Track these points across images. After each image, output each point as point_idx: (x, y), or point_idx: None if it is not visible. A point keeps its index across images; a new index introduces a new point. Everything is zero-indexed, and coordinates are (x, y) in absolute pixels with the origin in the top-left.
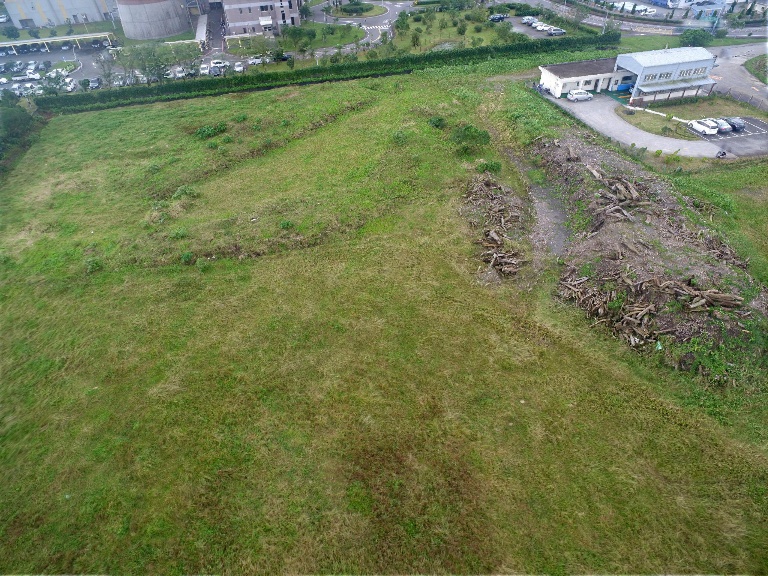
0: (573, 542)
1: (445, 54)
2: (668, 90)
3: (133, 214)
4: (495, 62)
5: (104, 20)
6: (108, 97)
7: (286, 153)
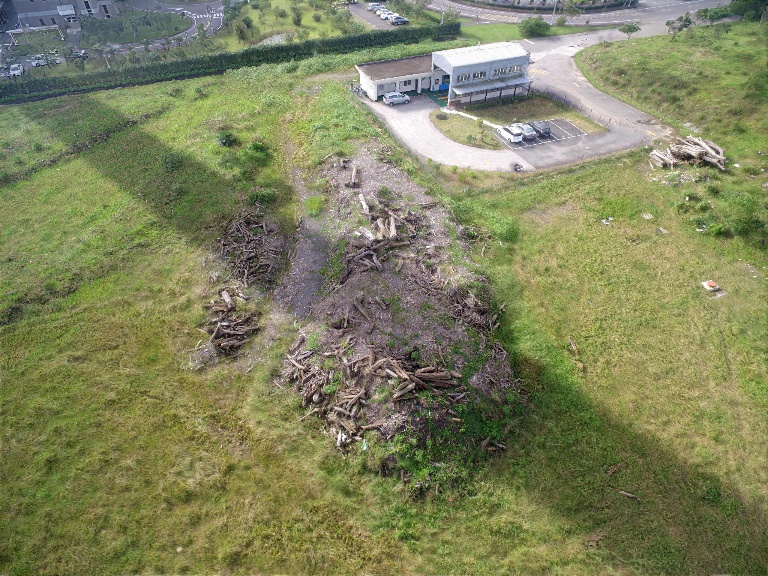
0: None
1: (265, 50)
2: None
3: None
4: (320, 58)
5: None
6: None
7: (26, 188)
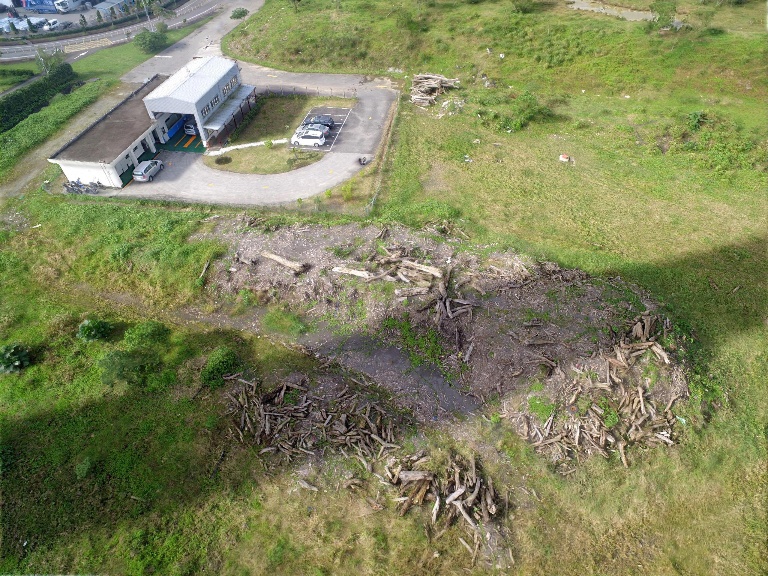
0: None
1: None
2: None
3: None
4: None
5: None
6: None
7: None
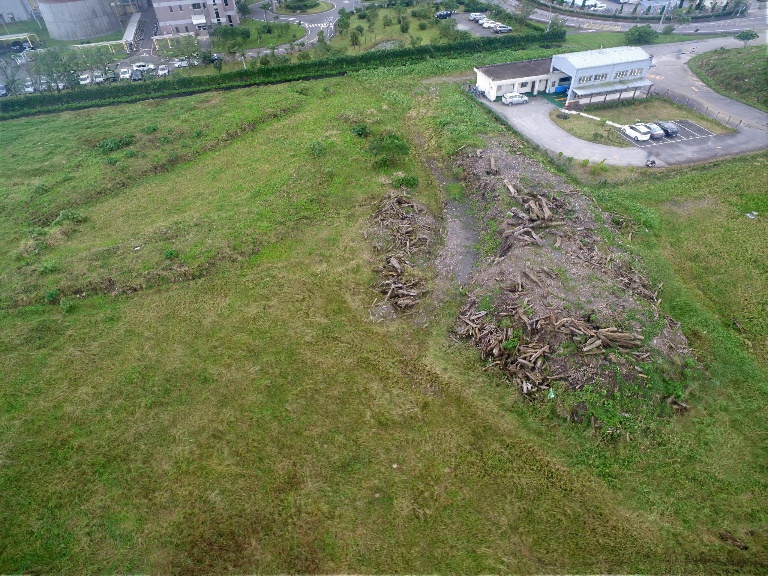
0: None
1: (382, 54)
2: (605, 92)
3: (7, 243)
4: (434, 62)
5: (25, 20)
6: (11, 106)
7: (193, 168)
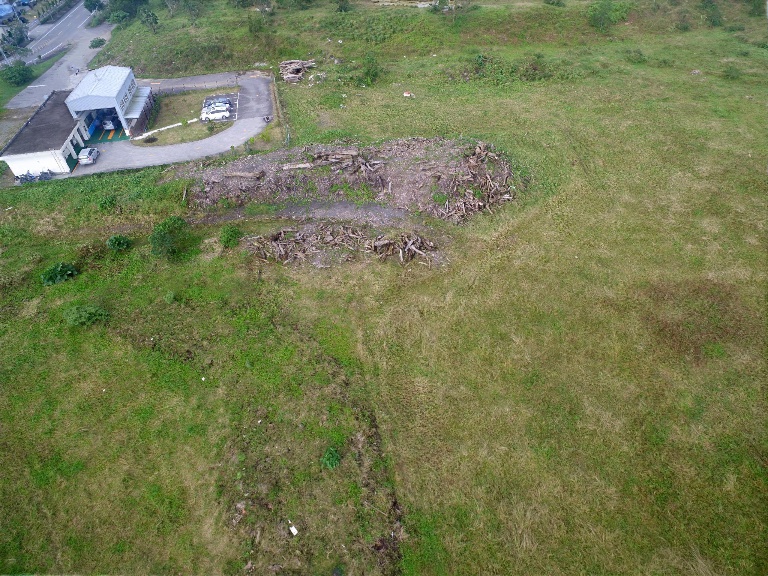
0: (672, 250)
1: None
2: None
3: None
4: None
5: None
6: None
7: None
